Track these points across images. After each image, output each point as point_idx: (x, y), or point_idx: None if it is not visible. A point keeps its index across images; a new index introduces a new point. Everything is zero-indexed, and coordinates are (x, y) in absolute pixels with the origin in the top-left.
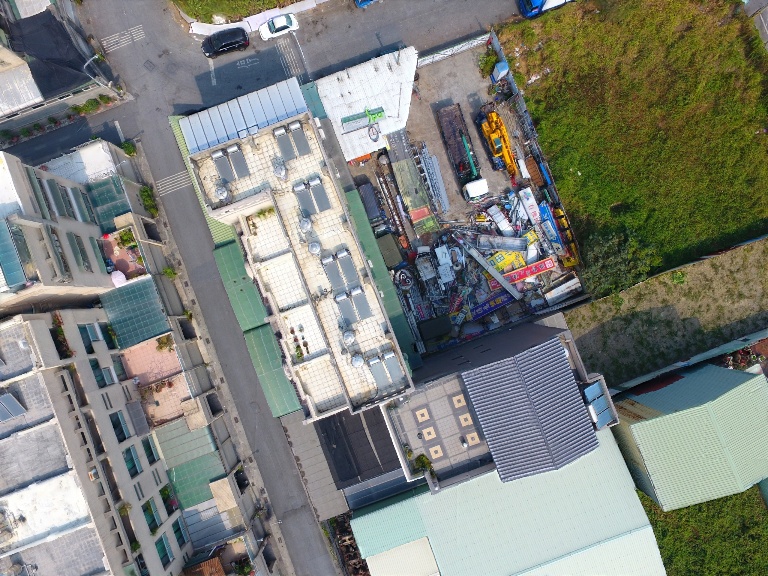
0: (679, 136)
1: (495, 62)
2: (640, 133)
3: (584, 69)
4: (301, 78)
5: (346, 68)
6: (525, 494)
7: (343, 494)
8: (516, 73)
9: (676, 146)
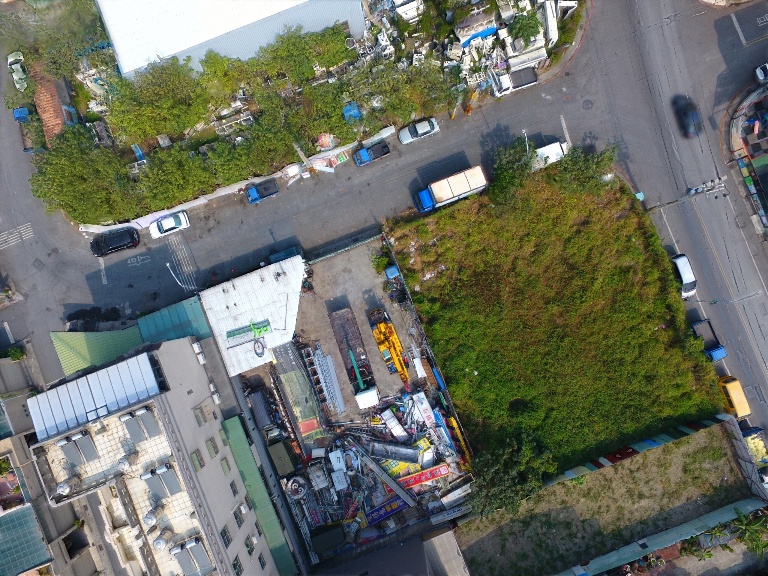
0: (577, 333)
1: (387, 264)
2: (537, 331)
3: (479, 266)
4: (193, 275)
5: (231, 279)
6: None
7: None
8: (409, 272)
9: (574, 343)
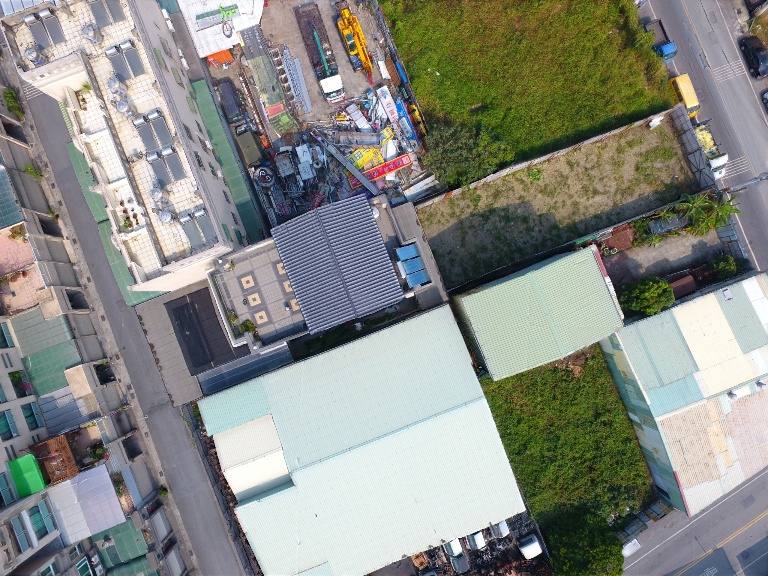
0: (535, 37)
1: None
2: (496, 33)
3: None
4: None
5: None
6: (367, 372)
7: (197, 380)
8: None
9: (532, 46)
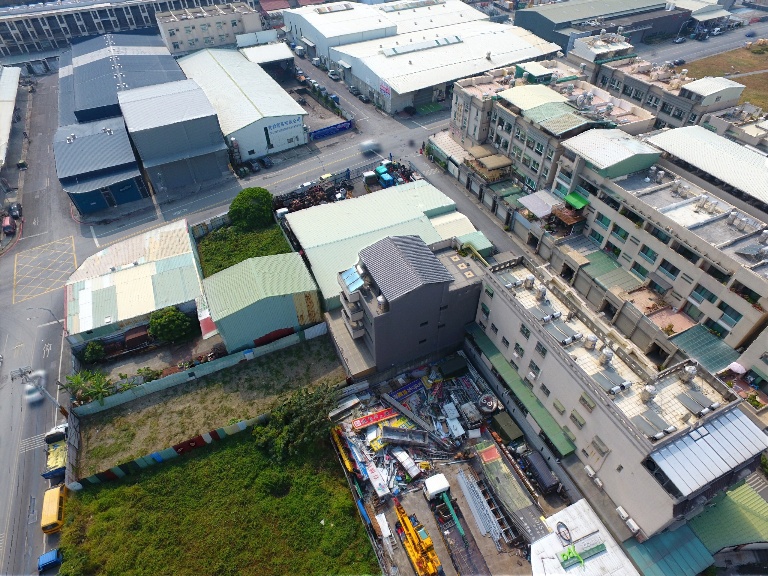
0: None
1: None
2: None
3: None
4: None
5: None
6: None
7: None
8: None
9: (208, 565)
